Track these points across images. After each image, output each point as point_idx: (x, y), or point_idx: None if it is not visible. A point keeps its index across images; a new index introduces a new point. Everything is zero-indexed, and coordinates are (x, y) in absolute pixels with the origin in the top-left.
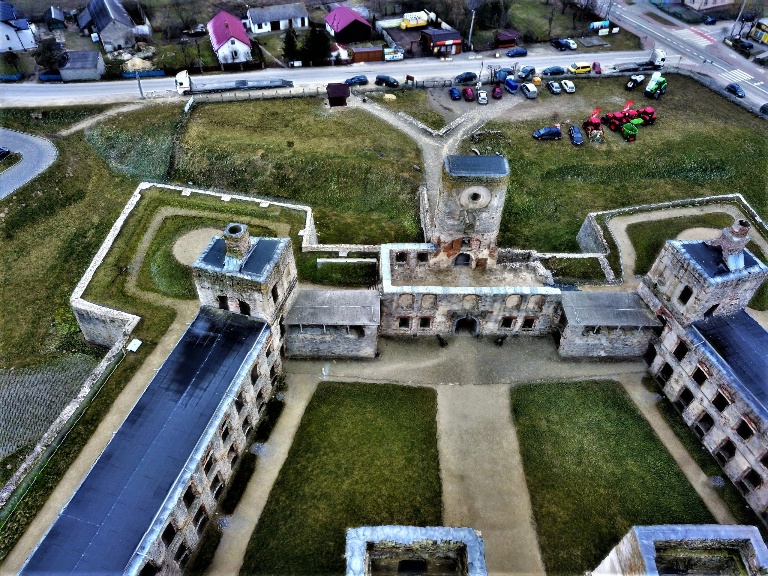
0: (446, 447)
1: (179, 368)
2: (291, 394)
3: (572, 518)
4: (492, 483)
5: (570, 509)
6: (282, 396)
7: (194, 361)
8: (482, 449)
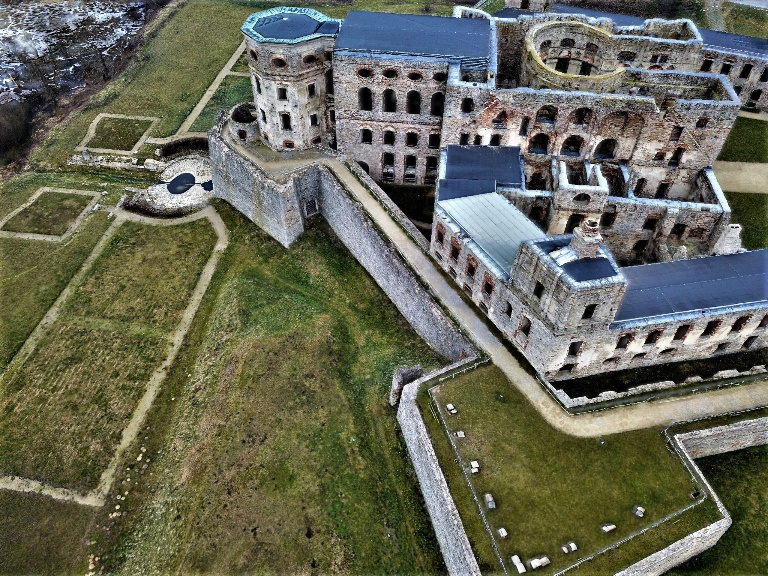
0: (759, 166)
1: (755, 40)
2: (767, 115)
3: (732, 207)
4: (742, 180)
5: (738, 207)
6: (763, 112)
7: (762, 43)
8: (765, 179)
